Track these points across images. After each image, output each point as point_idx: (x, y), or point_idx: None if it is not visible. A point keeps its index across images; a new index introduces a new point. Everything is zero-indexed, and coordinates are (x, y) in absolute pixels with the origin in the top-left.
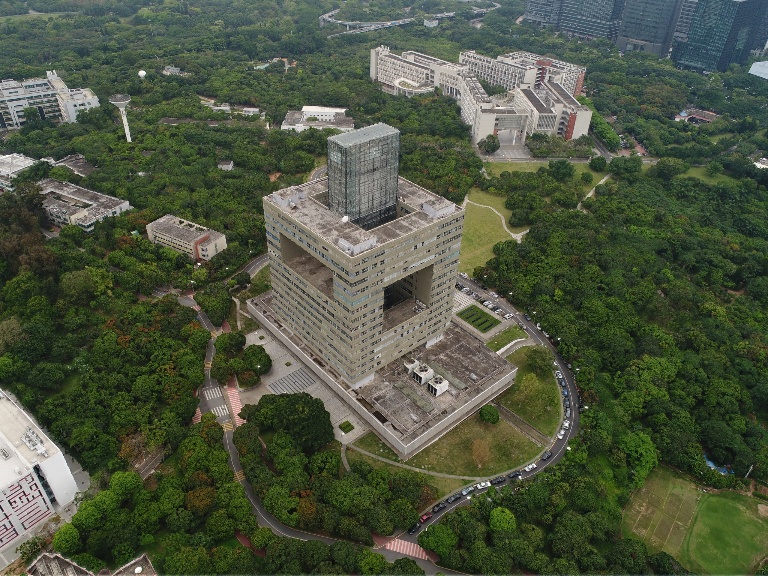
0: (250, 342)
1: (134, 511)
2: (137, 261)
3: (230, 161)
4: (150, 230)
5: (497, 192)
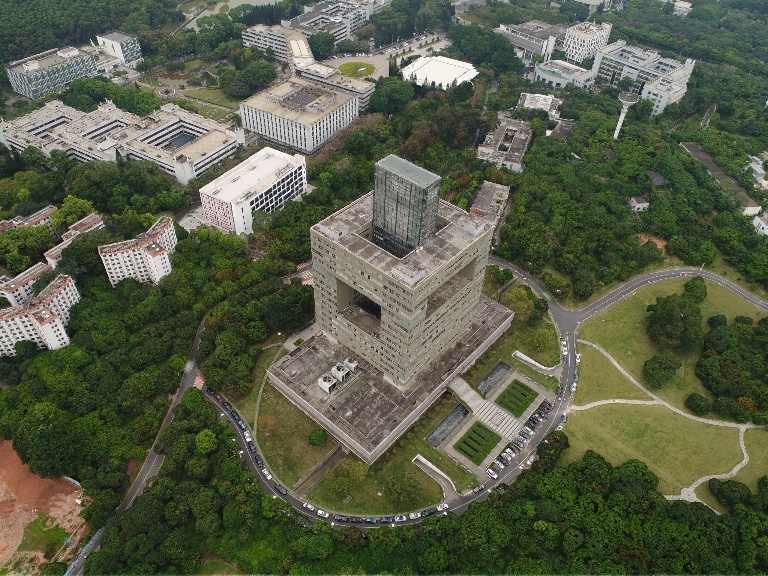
0: None
1: None
2: None
3: (647, 202)
4: None
5: None
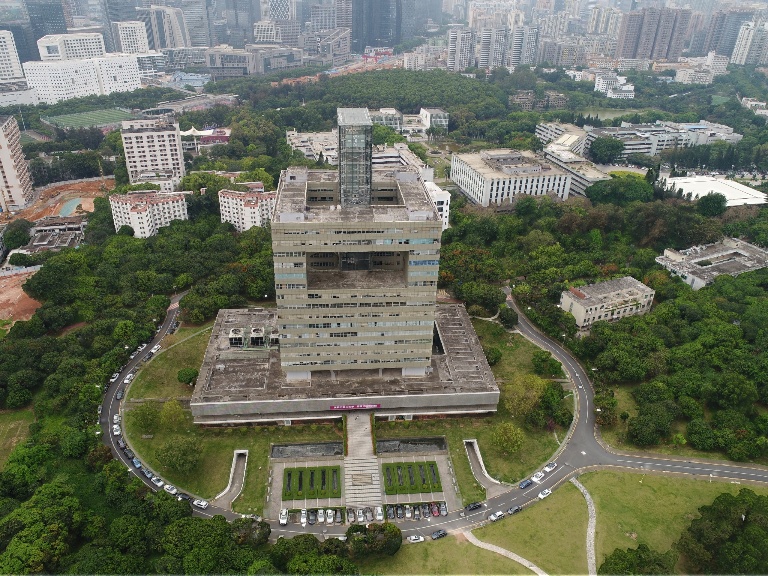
0: None
1: None
2: None
3: None
4: None
5: None
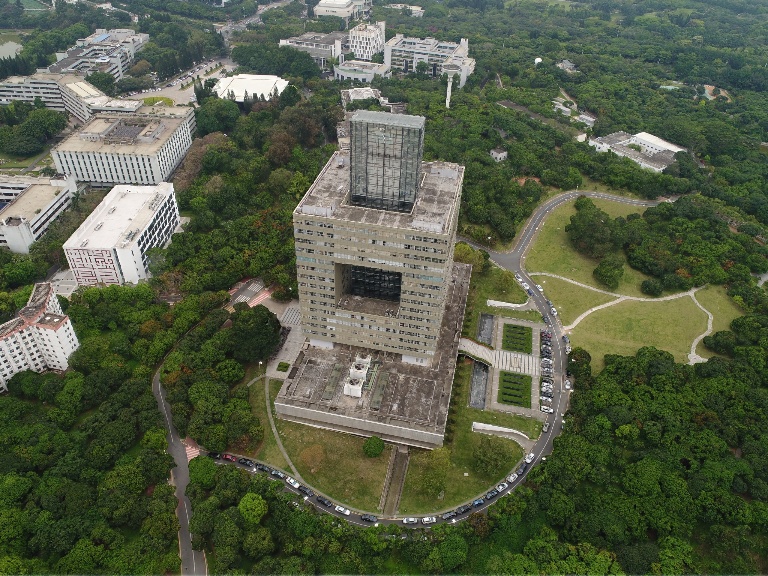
0: None
1: None
2: None
3: (505, 151)
4: None
5: (741, 304)
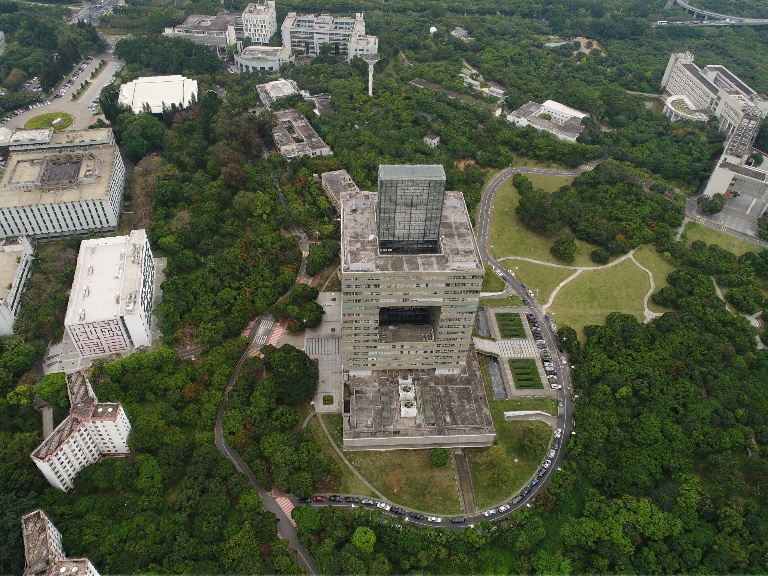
0: (323, 299)
1: (157, 375)
2: (302, 199)
3: (437, 136)
4: (323, 178)
5: (670, 259)
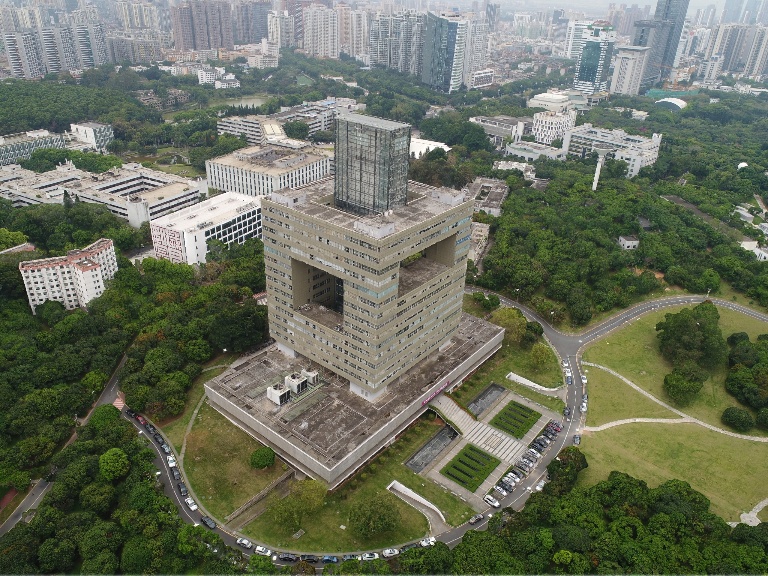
0: None
1: None
2: None
3: (637, 240)
4: None
5: None
